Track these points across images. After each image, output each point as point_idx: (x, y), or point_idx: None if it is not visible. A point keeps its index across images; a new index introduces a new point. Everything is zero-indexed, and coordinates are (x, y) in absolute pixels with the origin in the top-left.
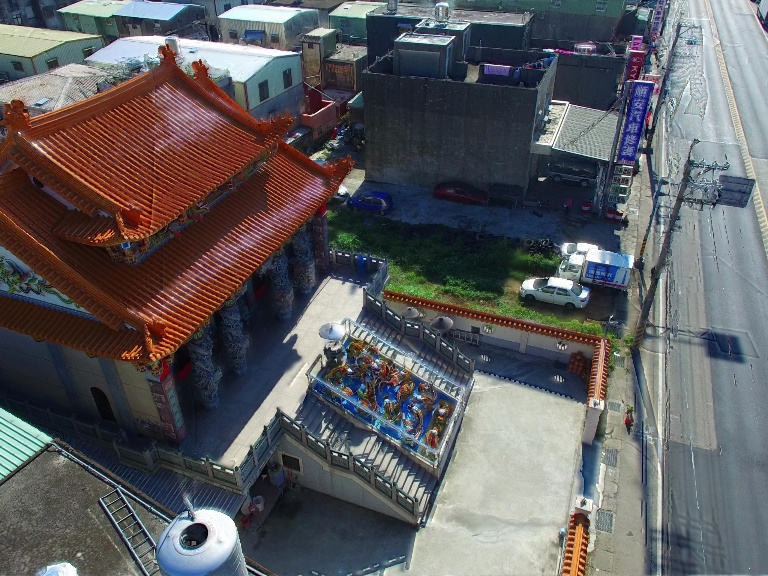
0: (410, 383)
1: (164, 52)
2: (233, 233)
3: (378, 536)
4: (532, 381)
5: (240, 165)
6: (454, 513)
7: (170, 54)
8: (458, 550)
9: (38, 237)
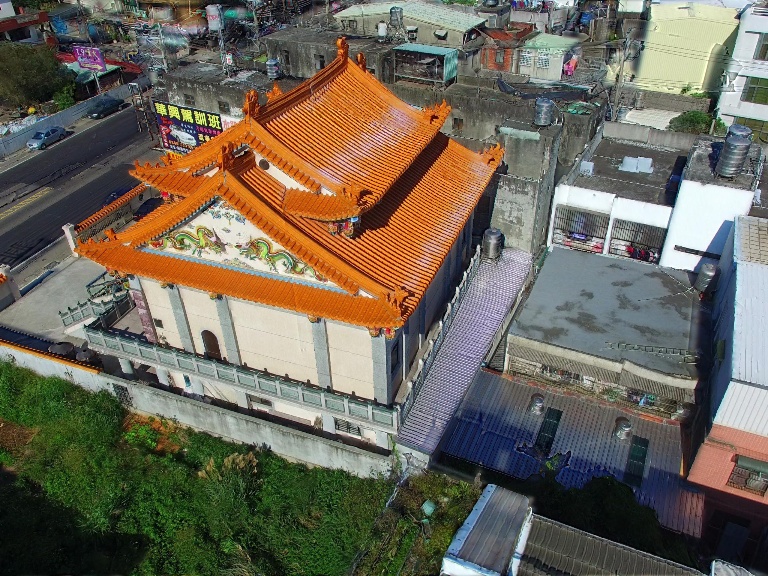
0: None
1: None
2: None
3: None
4: (15, 336)
5: None
6: None
7: None
8: None
9: None
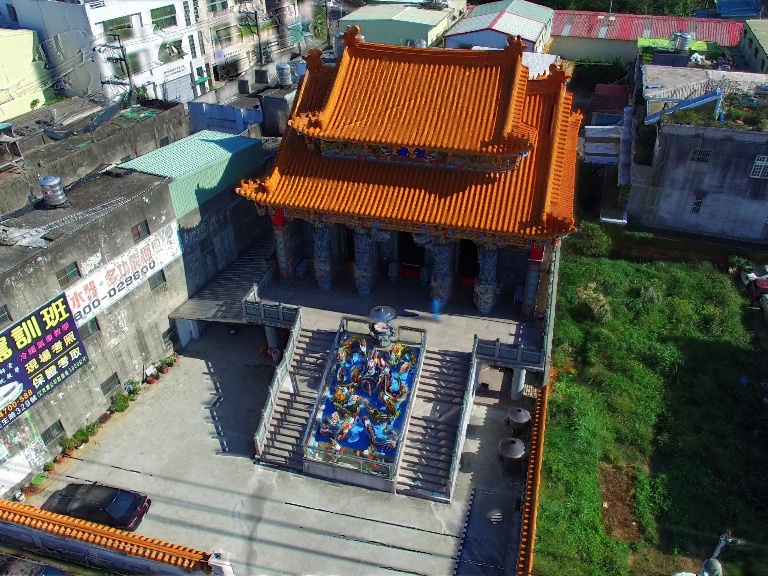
0: (387, 413)
1: (510, 41)
2: (395, 188)
3: (248, 432)
4: (465, 571)
5: (436, 145)
6: (267, 485)
7: (517, 45)
8: (229, 488)
9: (309, 108)
